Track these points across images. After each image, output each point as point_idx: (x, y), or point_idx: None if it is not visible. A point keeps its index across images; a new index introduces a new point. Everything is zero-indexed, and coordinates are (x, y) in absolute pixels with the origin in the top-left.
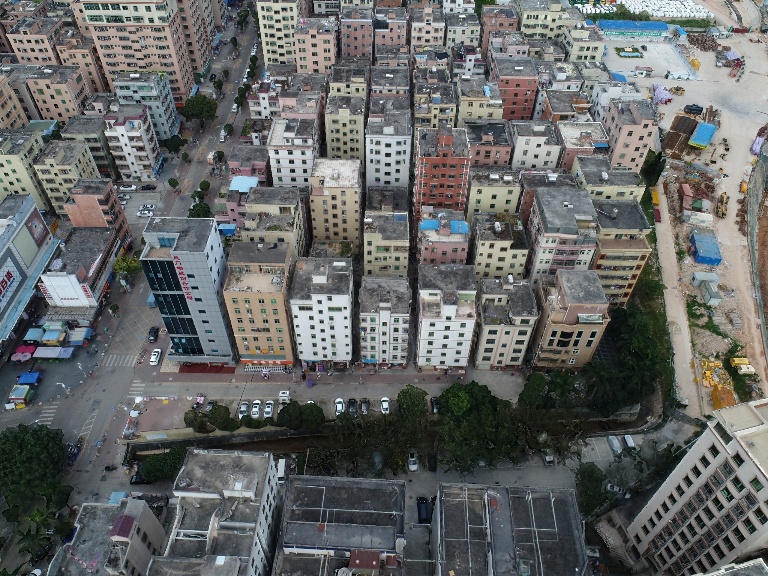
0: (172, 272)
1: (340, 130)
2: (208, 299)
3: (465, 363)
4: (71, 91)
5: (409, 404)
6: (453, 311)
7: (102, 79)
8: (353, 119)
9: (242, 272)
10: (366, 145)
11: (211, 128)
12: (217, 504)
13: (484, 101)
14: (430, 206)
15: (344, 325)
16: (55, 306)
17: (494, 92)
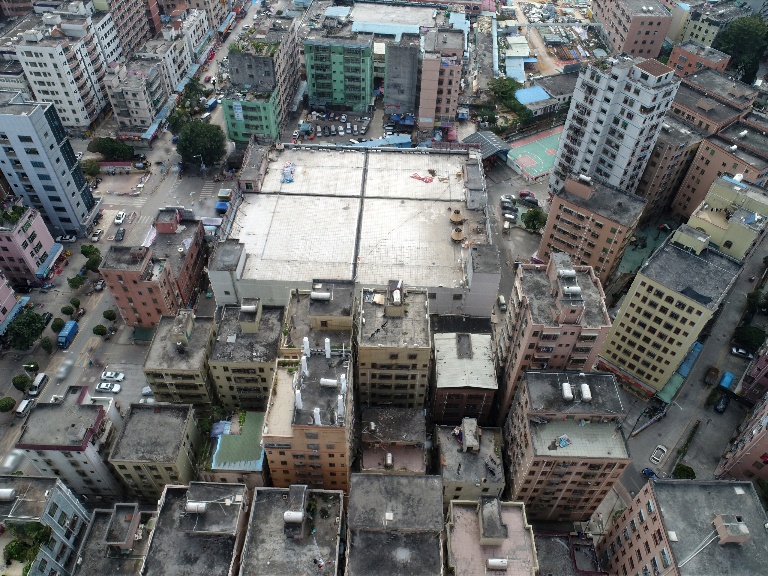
0: None
1: None
2: None
3: None
4: None
5: None
6: None
7: None
8: None
9: None
10: None
11: None
12: None
13: None
14: None
15: None
16: None
17: None
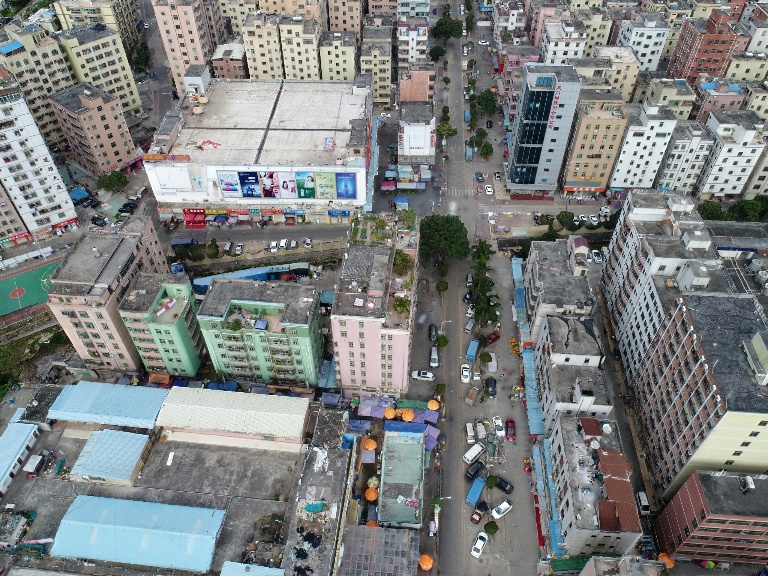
0: (548, 102)
1: (590, 34)
2: (564, 128)
3: (740, 190)
4: (359, 9)
5: (712, 210)
6: (751, 137)
7: (362, 6)
8: (603, 24)
9: (587, 109)
10: (631, 37)
11: (450, 47)
12: (655, 224)
13: (716, 7)
14: (705, 73)
15: (661, 151)
16: (402, 155)
17: None
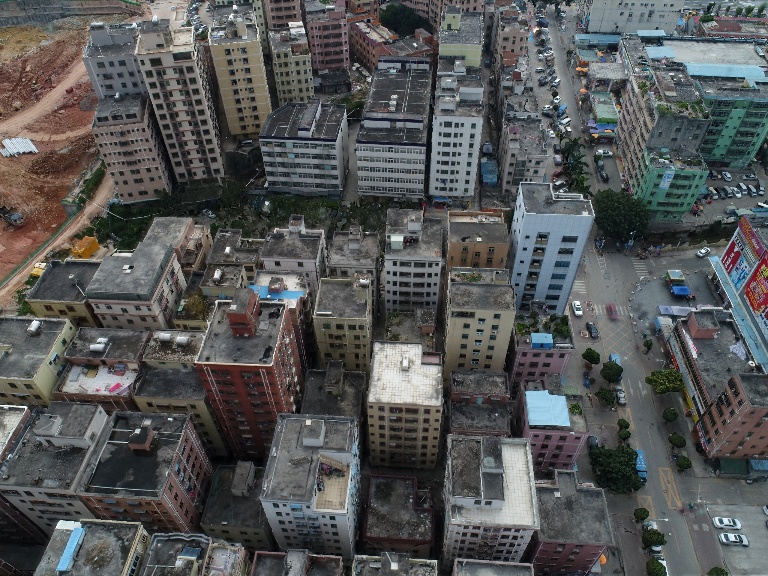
0: None
1: None
2: None
3: None
4: None
5: None
6: None
7: None
8: None
9: None
10: None
11: None
12: None
13: None
14: None
15: None
16: None
17: (50, 568)
